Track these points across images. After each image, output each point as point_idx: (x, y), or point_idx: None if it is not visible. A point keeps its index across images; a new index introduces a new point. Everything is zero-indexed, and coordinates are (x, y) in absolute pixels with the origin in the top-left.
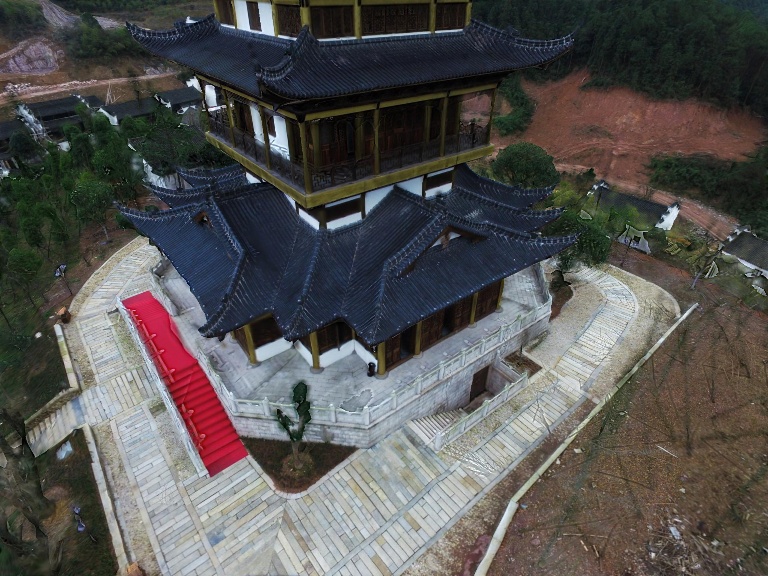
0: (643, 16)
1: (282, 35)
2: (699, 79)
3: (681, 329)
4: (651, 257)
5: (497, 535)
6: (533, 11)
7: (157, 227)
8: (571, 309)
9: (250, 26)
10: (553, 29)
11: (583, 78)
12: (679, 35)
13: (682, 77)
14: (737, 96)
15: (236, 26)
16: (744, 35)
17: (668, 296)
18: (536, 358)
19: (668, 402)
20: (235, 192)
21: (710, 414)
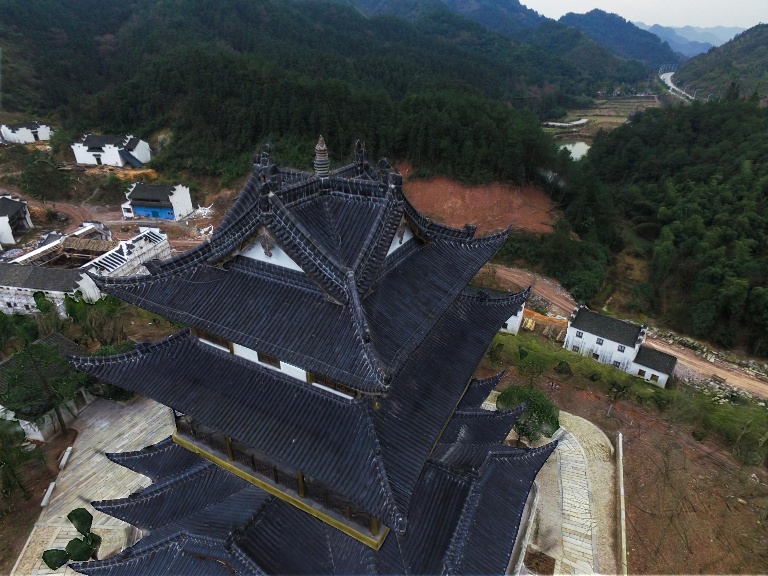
0: (442, 118)
1: (319, 384)
2: (496, 167)
3: (626, 469)
4: (561, 384)
5: None
6: (348, 113)
7: (133, 573)
8: (539, 472)
9: (259, 359)
10: (371, 130)
11: (406, 170)
12: (472, 132)
13: (484, 166)
14: (524, 176)
15: (232, 352)
16: (517, 131)
17: (595, 428)
18: (545, 549)
19: (667, 568)
20: (253, 521)
21: (697, 569)
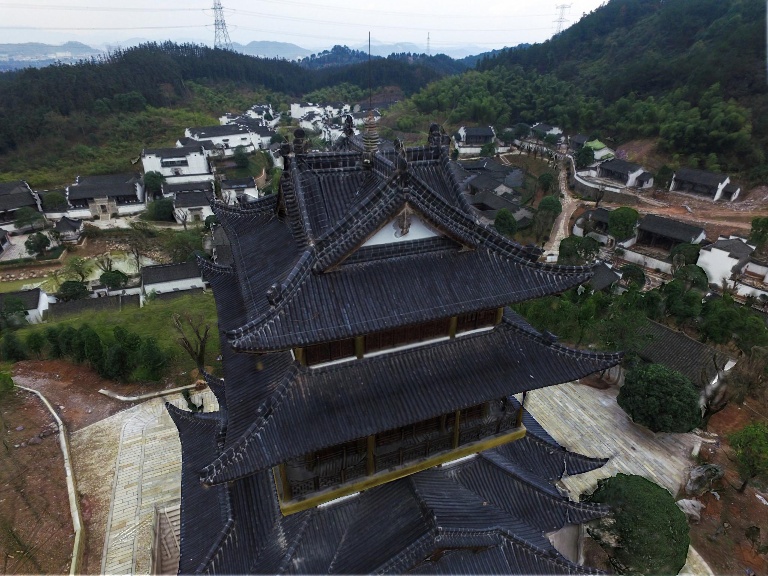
0: None
1: None
2: None
3: None
4: None
5: (76, 512)
6: None
7: None
8: None
9: None
10: None
11: None
12: None
13: None
14: None
15: None
16: None
17: None
18: None
19: None
20: None
21: None
